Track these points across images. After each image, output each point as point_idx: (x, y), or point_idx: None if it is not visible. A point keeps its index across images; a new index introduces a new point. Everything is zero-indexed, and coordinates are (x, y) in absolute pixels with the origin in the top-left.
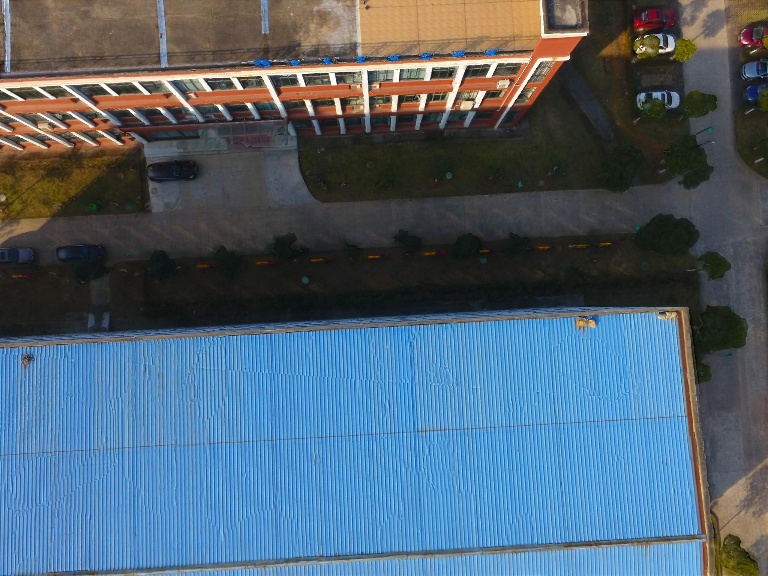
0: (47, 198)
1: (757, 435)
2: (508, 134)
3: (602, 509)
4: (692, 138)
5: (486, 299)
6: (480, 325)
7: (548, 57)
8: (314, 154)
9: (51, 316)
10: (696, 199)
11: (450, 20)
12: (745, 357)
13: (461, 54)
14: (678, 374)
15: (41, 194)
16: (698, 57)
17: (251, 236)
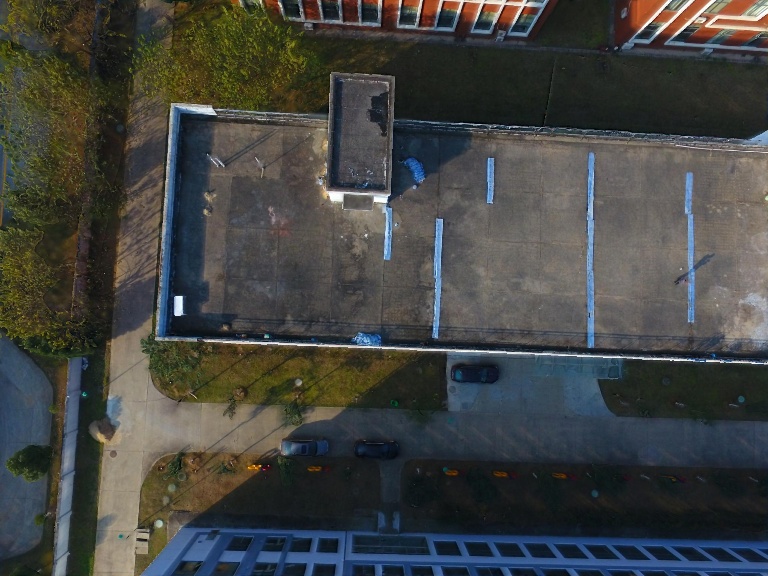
0: (344, 387)
1: None
2: None
3: None
4: None
5: None
6: None
7: None
8: None
9: (339, 511)
10: None
11: None
12: None
13: None
14: None
15: (338, 382)
16: None
17: (545, 444)
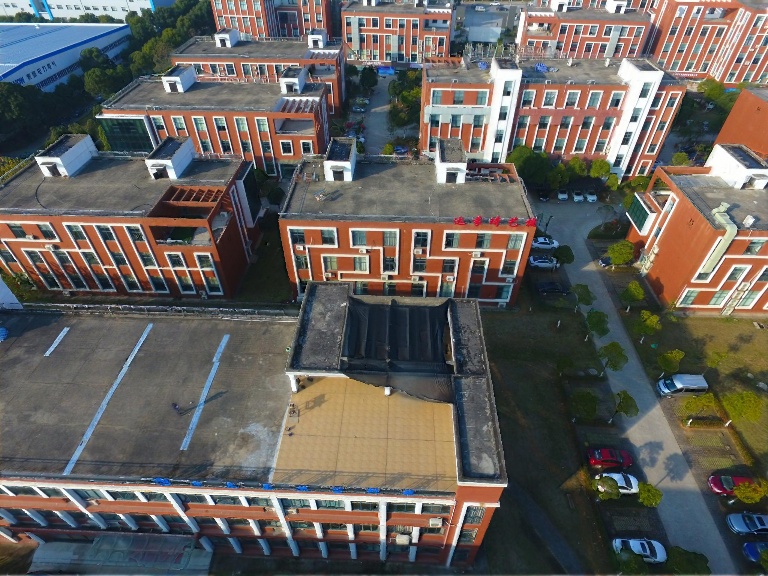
0: None
1: None
2: (463, 575)
3: None
4: None
5: None
6: None
7: (475, 502)
8: None
9: None
10: None
11: (371, 453)
12: None
13: (376, 491)
14: None
15: None
16: (671, 501)
17: None
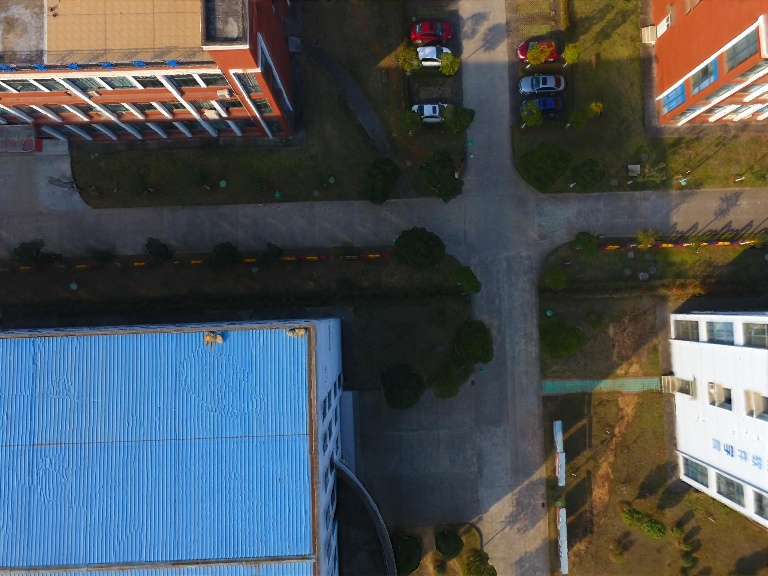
0: None
1: (525, 451)
2: (284, 143)
3: (214, 527)
4: (439, 152)
5: (254, 309)
6: (106, 338)
7: (237, 69)
8: (87, 159)
9: None
10: (471, 212)
11: (138, 29)
12: (515, 372)
13: (142, 64)
14: (303, 392)
15: None
16: (478, 70)
17: (20, 240)
